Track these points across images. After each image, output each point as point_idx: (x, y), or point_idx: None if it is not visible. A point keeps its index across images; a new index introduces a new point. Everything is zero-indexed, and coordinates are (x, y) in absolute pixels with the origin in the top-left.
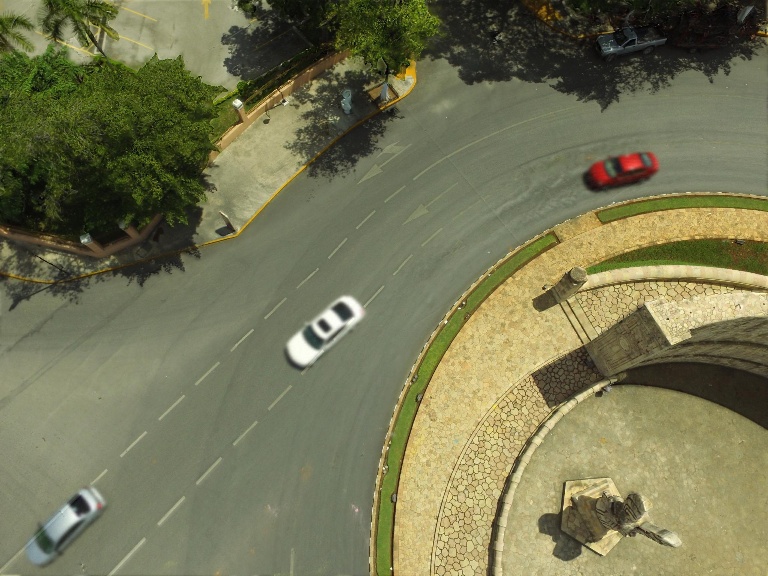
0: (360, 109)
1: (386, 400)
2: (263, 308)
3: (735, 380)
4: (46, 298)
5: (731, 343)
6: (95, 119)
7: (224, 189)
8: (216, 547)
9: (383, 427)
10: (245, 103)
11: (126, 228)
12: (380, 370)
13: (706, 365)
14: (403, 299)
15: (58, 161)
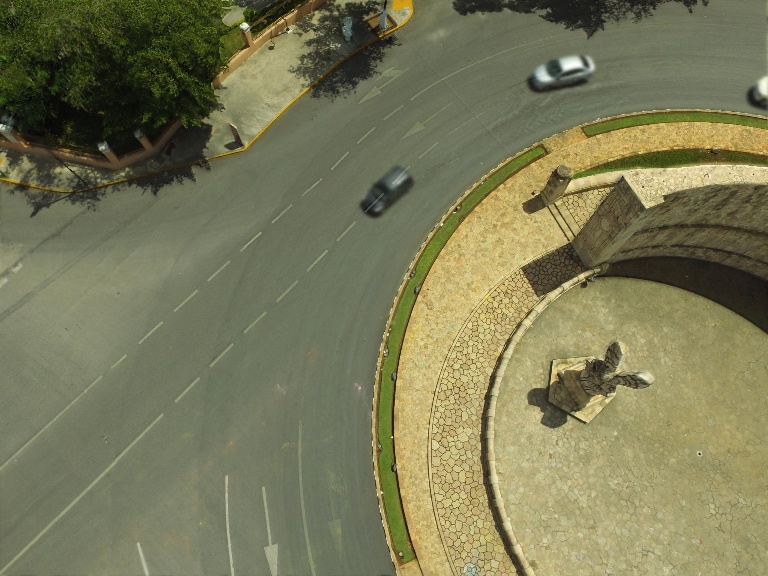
0: (360, 37)
1: (386, 293)
2: (270, 214)
3: (709, 272)
4: (65, 206)
5: (704, 226)
6: (118, 11)
7: (232, 108)
8: (229, 421)
9: (384, 316)
10: (251, 31)
11: (141, 137)
12: (380, 267)
13: (683, 259)
14: (402, 205)
15: (84, 49)
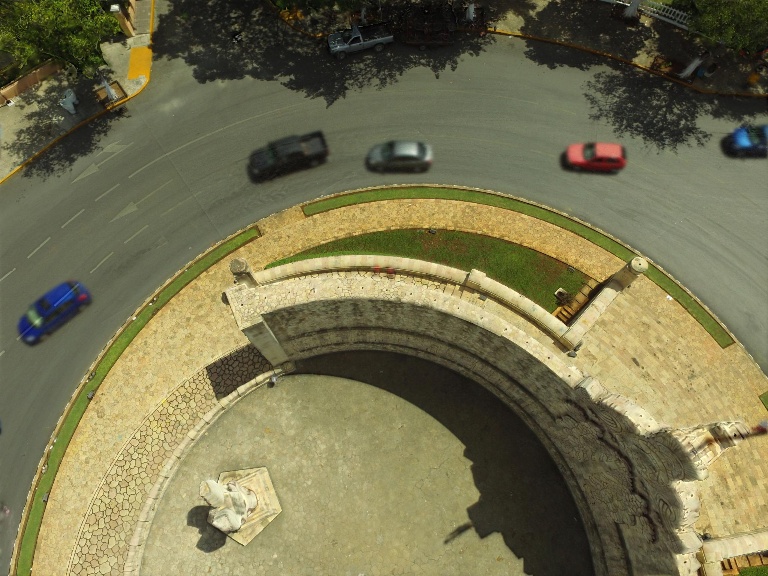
0: (86, 109)
1: (59, 398)
2: None
3: (406, 366)
4: None
5: (364, 329)
6: None
7: None
8: None
9: (51, 426)
10: None
11: None
12: (59, 369)
13: (380, 352)
14: (96, 297)
15: None
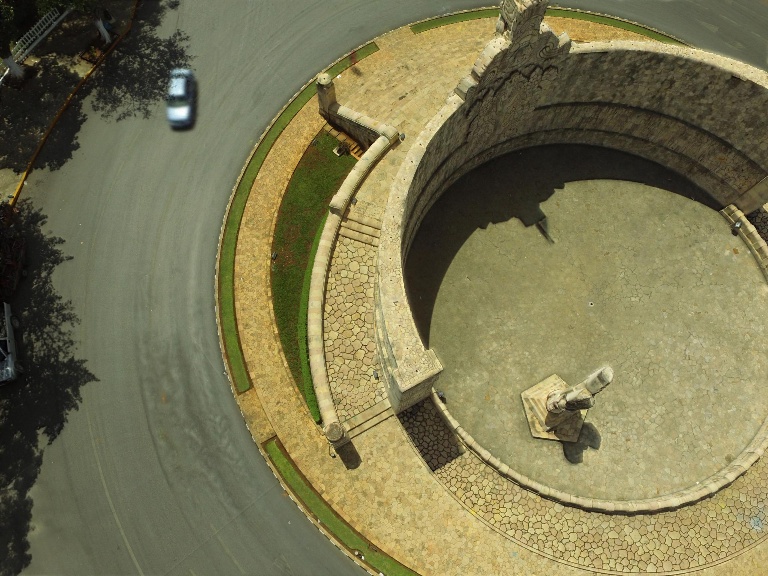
0: None
1: None
2: None
3: (413, 277)
4: None
5: None
6: None
7: None
8: None
9: None
10: None
11: None
12: None
13: None
14: None
15: None
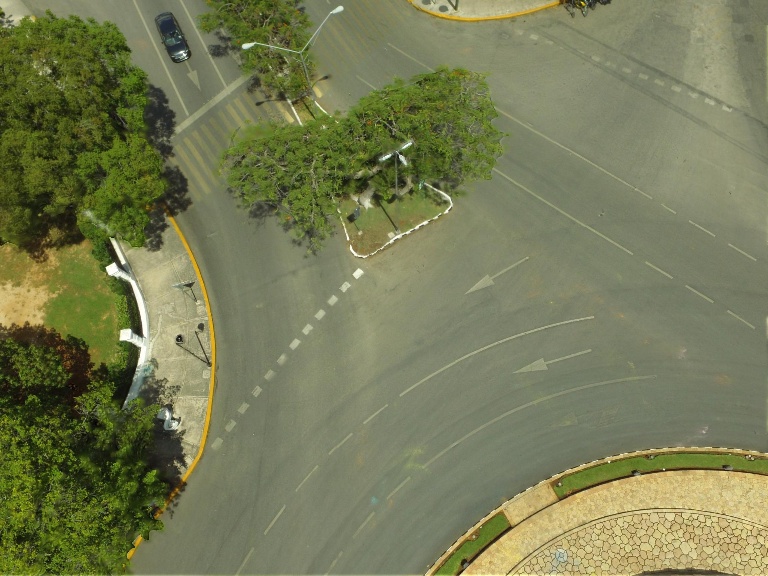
0: None
1: None
2: None
3: None
4: None
5: None
6: None
7: None
8: (641, 311)
9: None
10: None
11: None
12: None
13: None
14: None
15: None
